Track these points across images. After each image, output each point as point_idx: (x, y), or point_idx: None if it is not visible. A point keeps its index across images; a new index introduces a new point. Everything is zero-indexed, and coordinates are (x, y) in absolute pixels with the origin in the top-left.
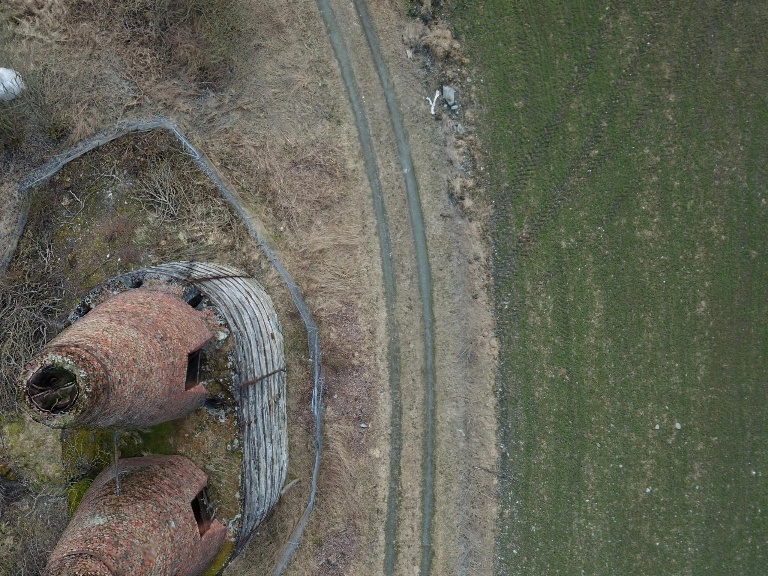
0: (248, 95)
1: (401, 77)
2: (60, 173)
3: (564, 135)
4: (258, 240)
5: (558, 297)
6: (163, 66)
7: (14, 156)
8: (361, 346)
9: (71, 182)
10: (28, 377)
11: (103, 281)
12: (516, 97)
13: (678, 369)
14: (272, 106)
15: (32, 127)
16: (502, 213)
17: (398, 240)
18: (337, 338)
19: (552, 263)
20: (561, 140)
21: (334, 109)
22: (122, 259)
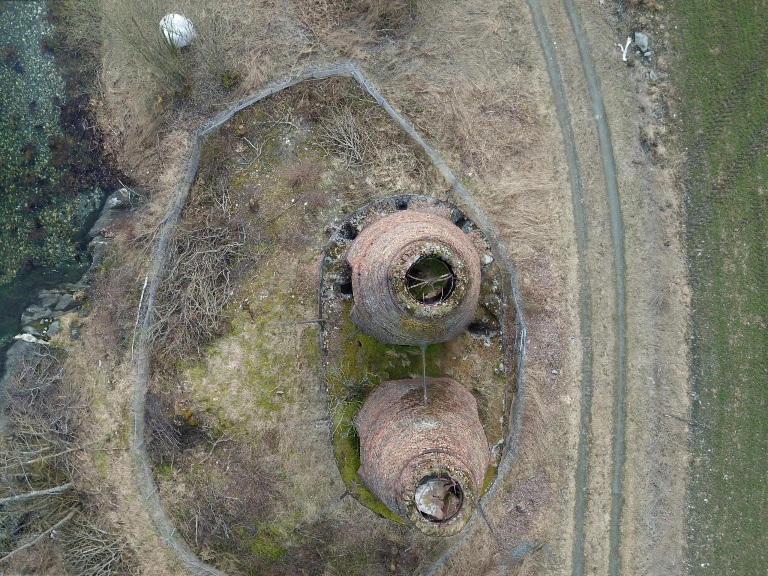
0: (432, 42)
1: (593, 23)
2: (231, 121)
3: (762, 81)
4: (447, 185)
5: (754, 244)
6: (341, 13)
7: (184, 104)
8: (553, 292)
9: (245, 129)
10: (406, 267)
11: (289, 225)
12: (712, 43)
13: None
14: (459, 52)
15: (202, 75)
16: (696, 160)
17: (590, 186)
18: (530, 283)
19: (748, 210)
20: (759, 87)
21: (525, 55)
22: (311, 203)
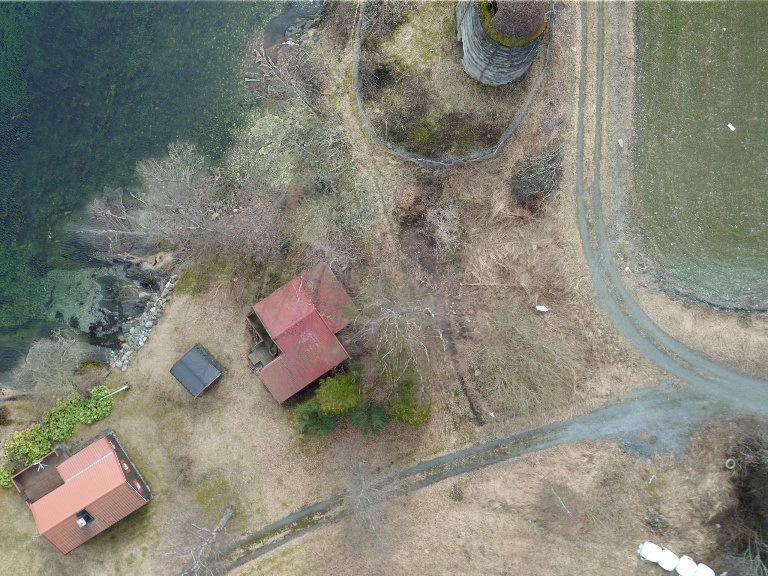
0: None
1: None
2: None
3: None
4: None
5: None
6: None
7: None
8: None
9: None
10: None
11: None
12: None
13: (725, 2)
14: None
15: None
16: None
17: None
18: None
19: None
20: None
21: None
22: None
